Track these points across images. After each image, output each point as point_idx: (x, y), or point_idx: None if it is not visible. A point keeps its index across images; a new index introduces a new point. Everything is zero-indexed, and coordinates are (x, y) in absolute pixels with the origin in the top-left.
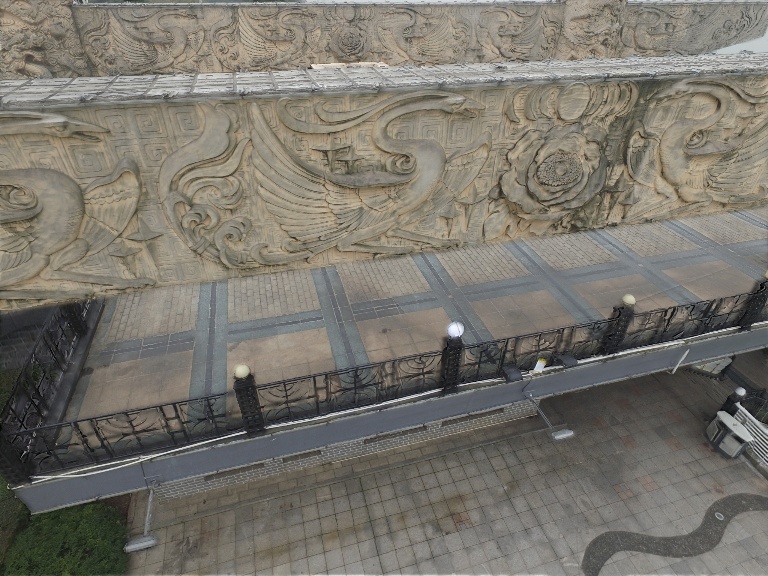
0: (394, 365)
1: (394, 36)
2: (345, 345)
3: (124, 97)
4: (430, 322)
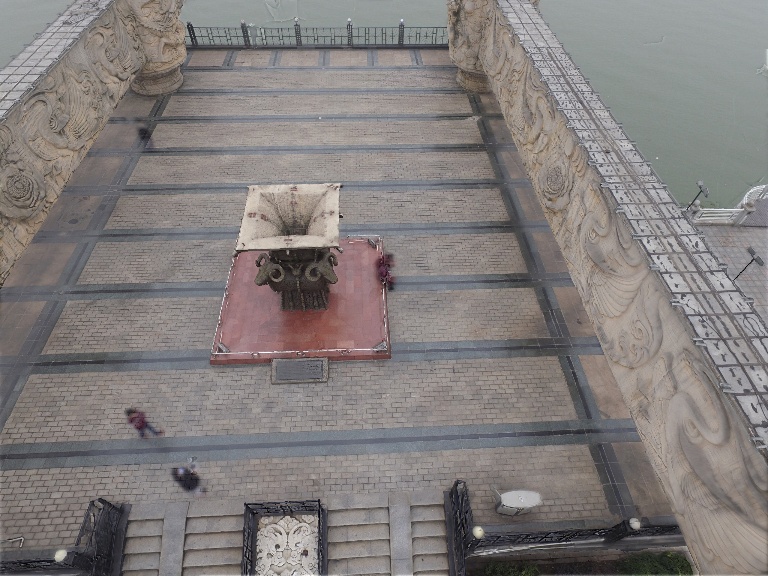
0: None
1: (47, 140)
2: (596, 346)
3: (763, 323)
4: (569, 297)
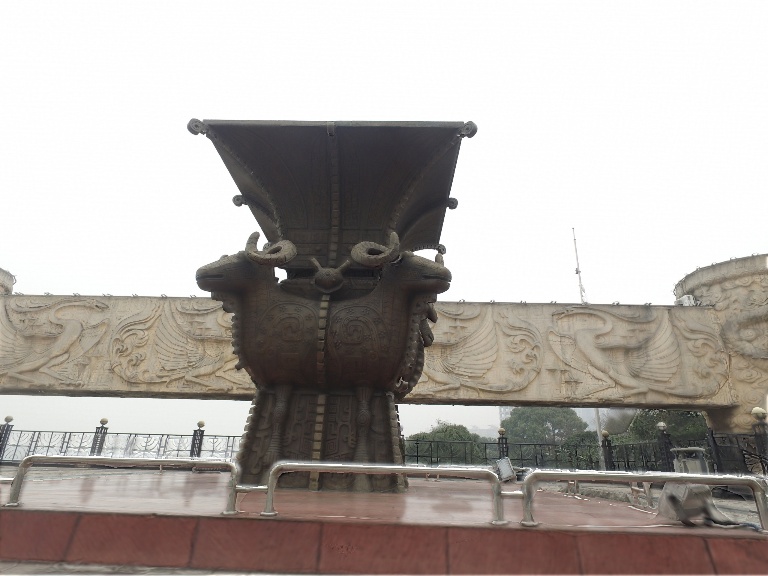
0: (431, 446)
1: None
2: None
3: None
4: None
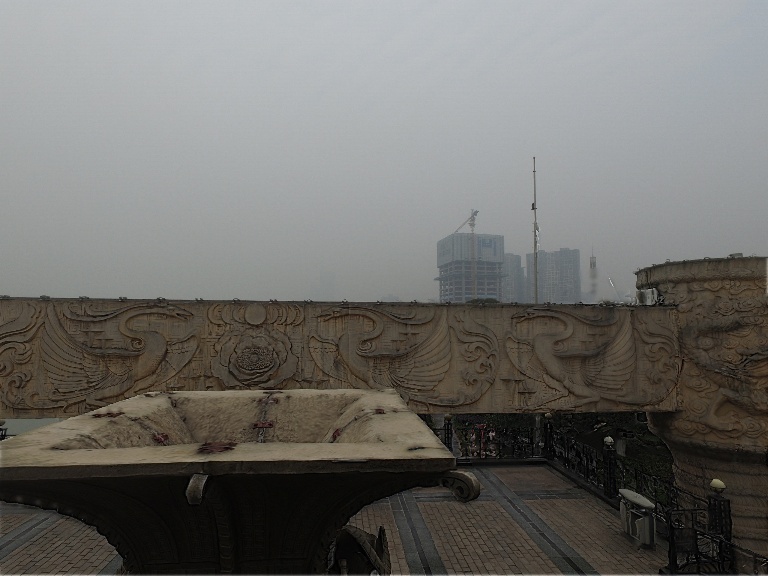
0: None
1: None
2: None
3: None
4: None
